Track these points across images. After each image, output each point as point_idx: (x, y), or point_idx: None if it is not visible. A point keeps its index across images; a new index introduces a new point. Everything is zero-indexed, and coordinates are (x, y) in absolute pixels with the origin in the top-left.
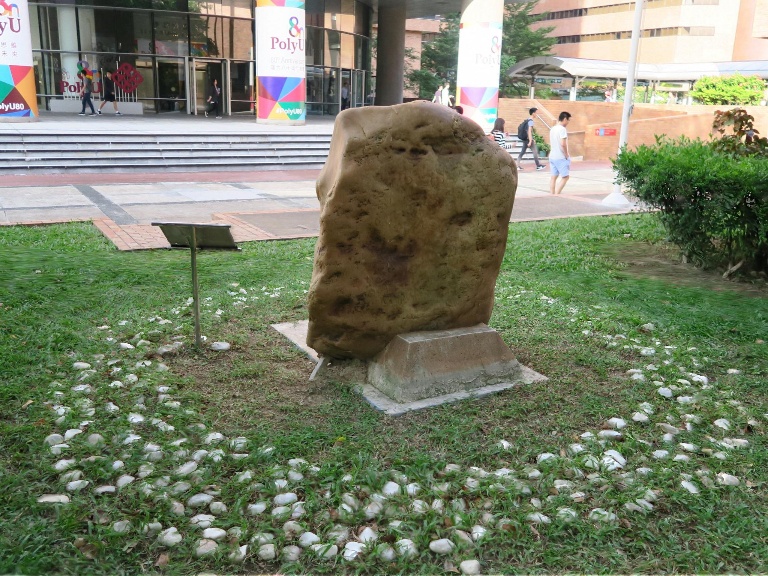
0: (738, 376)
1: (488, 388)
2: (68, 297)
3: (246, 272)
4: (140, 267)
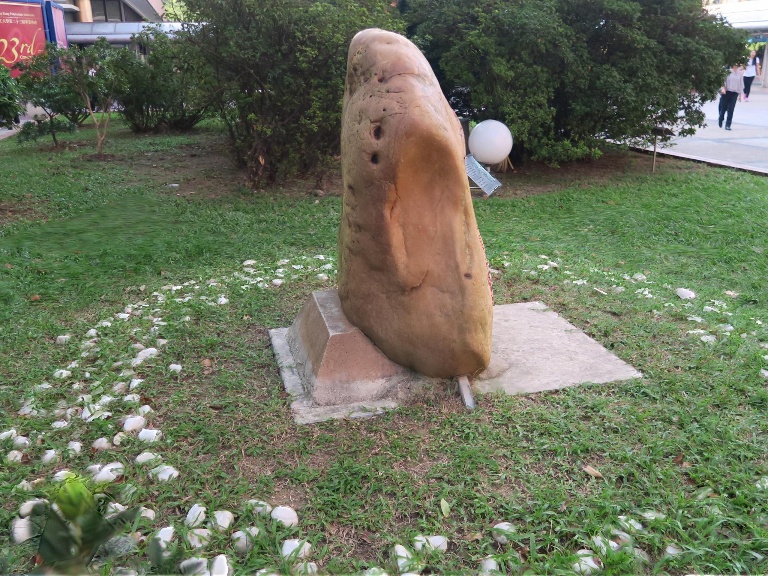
0: None
1: (294, 379)
2: (626, 240)
3: None
4: None
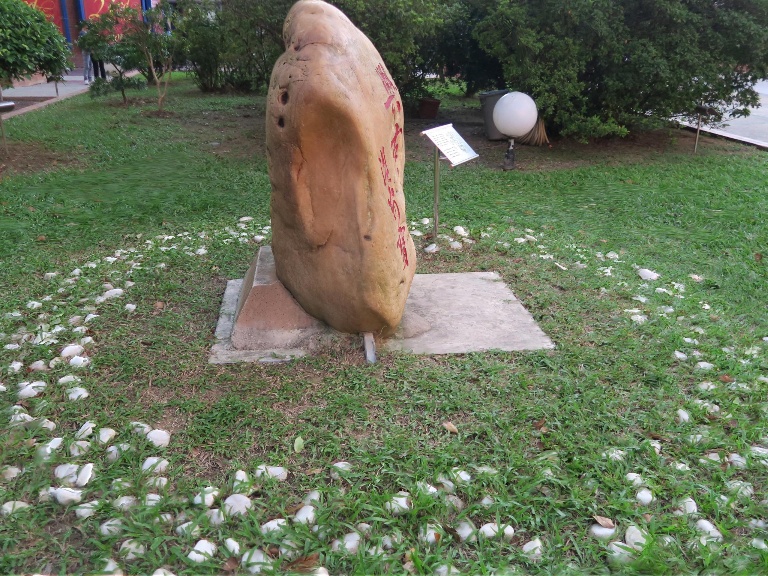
0: (20, 556)
1: (227, 325)
2: (621, 219)
3: (764, 283)
4: (762, 240)
